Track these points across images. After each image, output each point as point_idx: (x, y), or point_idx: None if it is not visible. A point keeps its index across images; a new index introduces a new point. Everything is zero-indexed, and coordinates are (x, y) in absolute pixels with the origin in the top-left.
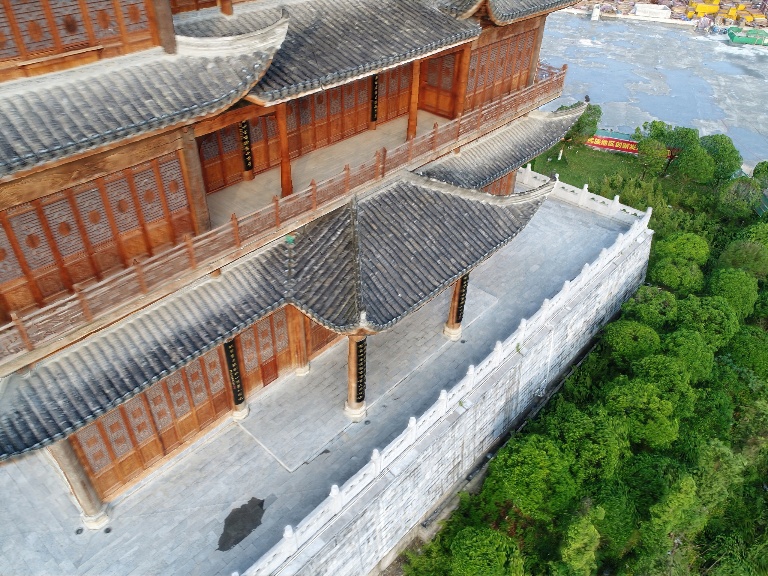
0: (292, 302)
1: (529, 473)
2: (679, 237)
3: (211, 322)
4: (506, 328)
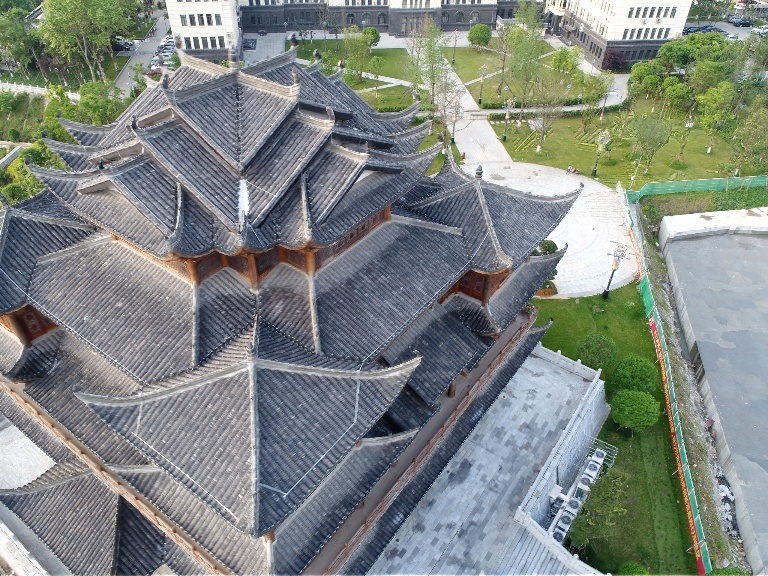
0: None
1: None
2: None
3: None
4: None
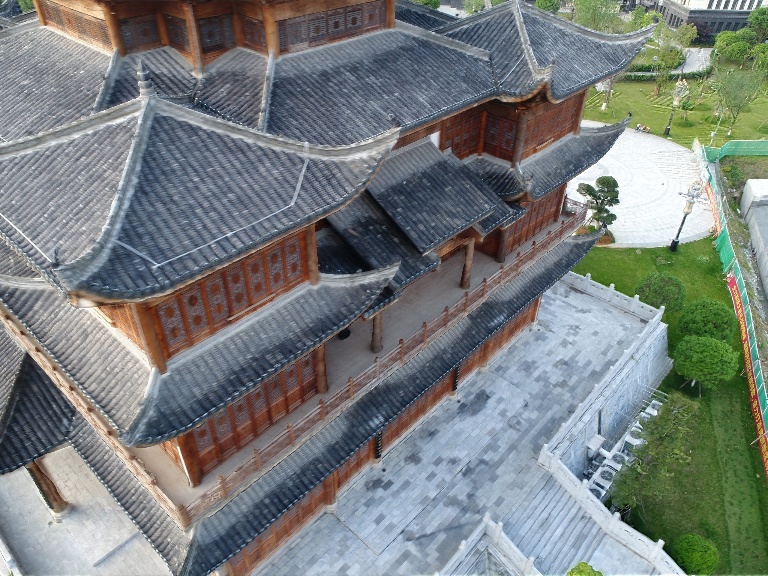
0: None
1: None
2: None
3: None
4: (50, 568)
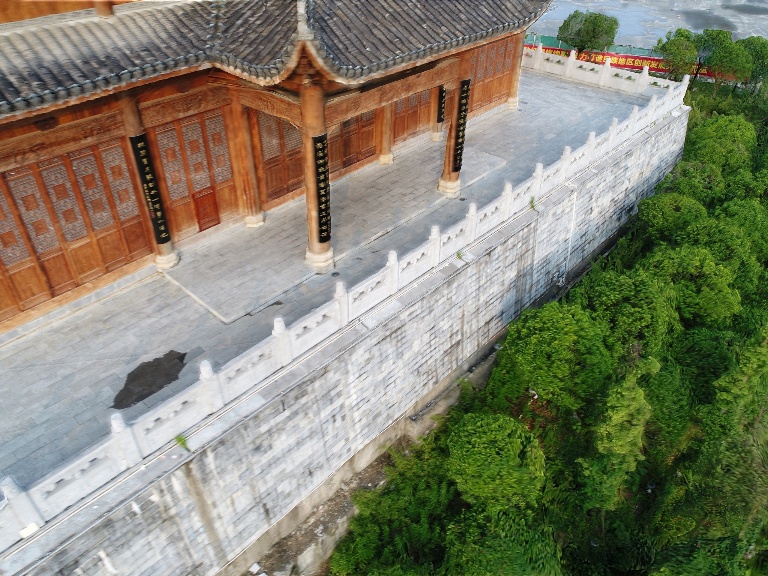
0: (217, 60)
1: (550, 341)
2: (720, 119)
3: (91, 63)
4: None
